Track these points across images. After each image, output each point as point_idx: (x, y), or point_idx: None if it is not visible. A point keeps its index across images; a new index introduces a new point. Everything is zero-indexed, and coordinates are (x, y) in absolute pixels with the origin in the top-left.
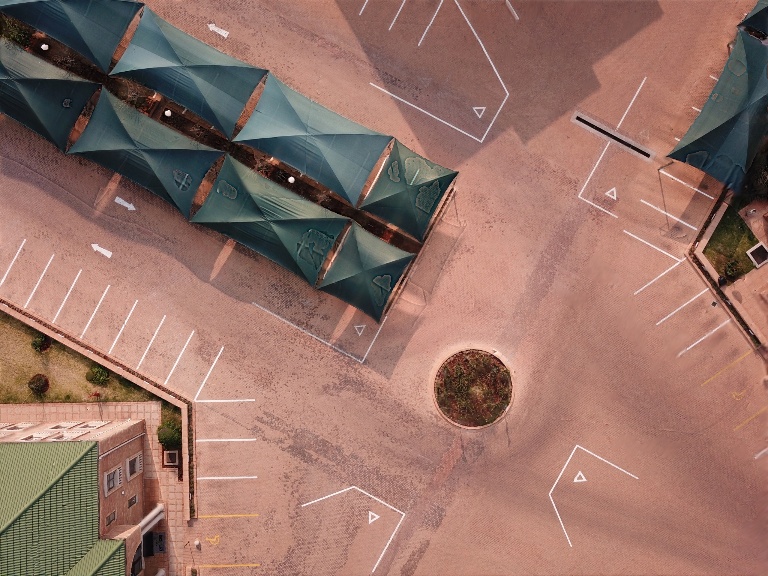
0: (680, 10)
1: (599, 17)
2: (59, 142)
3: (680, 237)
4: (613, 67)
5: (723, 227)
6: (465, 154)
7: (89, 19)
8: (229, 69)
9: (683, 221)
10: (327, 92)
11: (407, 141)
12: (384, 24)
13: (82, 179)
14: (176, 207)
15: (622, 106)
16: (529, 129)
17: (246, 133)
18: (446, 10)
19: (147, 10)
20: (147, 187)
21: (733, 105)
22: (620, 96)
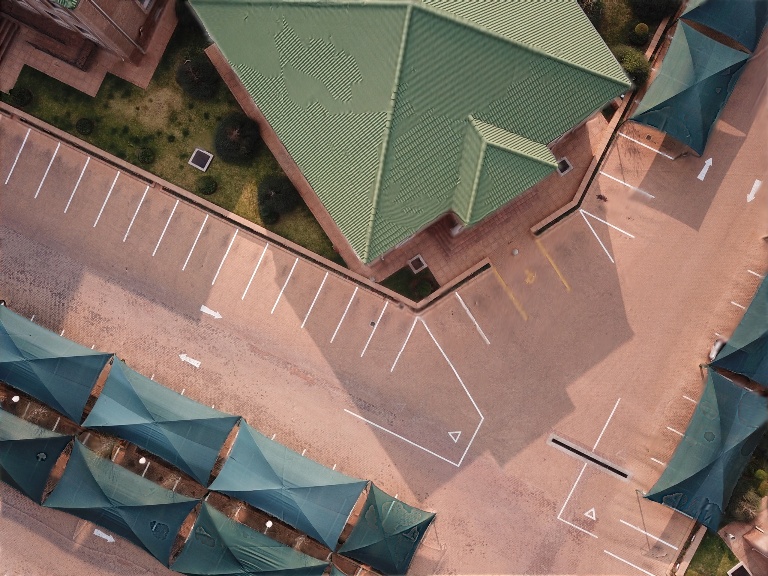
0: (651, 331)
1: (570, 340)
2: (34, 496)
3: (661, 556)
4: (586, 389)
5: (703, 548)
6: (443, 478)
7: (59, 376)
8: (201, 422)
9: (663, 540)
10: (302, 419)
11: (384, 466)
12: (356, 351)
13: (60, 512)
14: (155, 557)
15: (597, 427)
16: (505, 452)
17: (222, 482)
18: (417, 336)
19: (117, 361)
20: (125, 537)
21: (707, 453)
22: (595, 418)
